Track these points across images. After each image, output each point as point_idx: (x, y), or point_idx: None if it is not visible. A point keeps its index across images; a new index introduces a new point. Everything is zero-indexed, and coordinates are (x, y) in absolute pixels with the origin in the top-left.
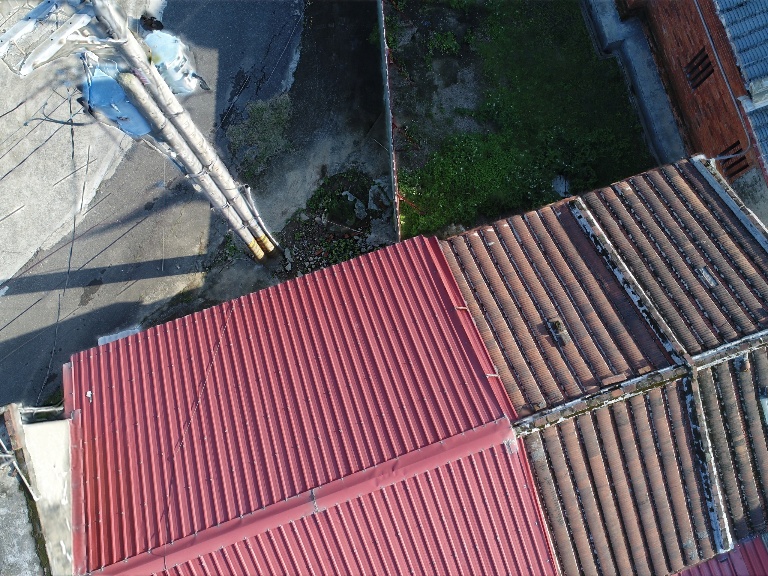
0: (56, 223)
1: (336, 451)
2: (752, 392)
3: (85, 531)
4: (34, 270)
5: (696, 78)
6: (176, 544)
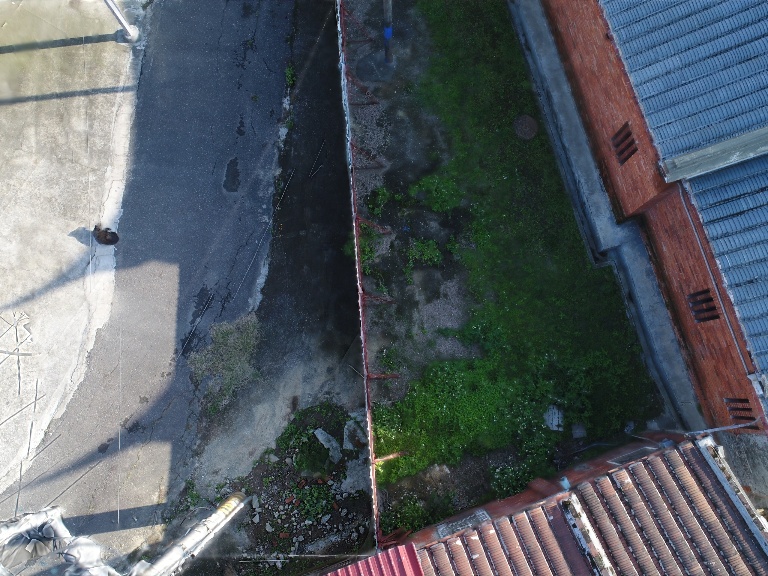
0: (0, 471)
1: None
2: None
3: None
4: None
5: (700, 313)
6: None
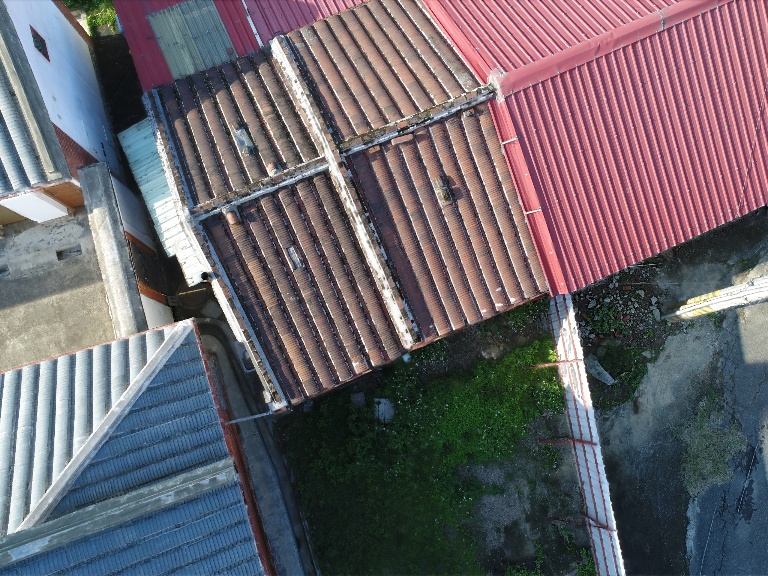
0: None
1: (644, 65)
2: (262, 150)
3: None
4: None
5: None
6: None
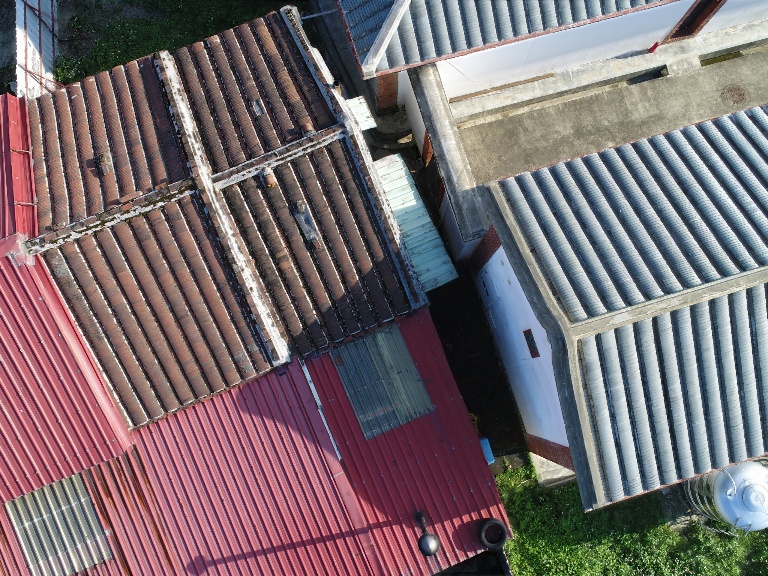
0: None
1: None
2: (285, 208)
3: None
4: None
5: None
6: None
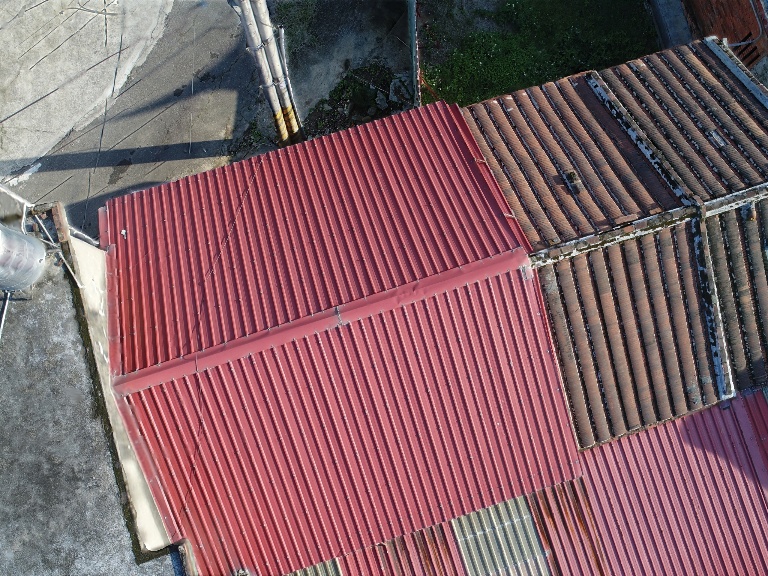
0: (88, 106)
1: (359, 276)
2: (758, 242)
3: (120, 342)
4: (66, 149)
5: None
6: (207, 351)
